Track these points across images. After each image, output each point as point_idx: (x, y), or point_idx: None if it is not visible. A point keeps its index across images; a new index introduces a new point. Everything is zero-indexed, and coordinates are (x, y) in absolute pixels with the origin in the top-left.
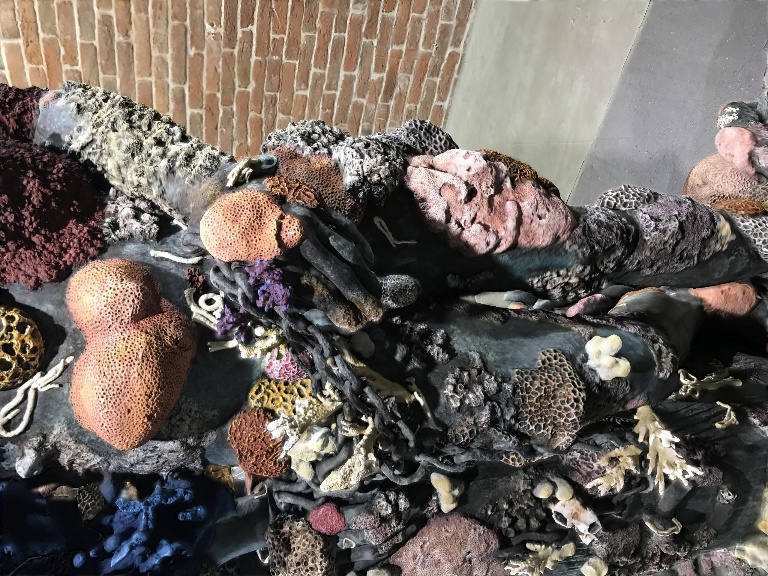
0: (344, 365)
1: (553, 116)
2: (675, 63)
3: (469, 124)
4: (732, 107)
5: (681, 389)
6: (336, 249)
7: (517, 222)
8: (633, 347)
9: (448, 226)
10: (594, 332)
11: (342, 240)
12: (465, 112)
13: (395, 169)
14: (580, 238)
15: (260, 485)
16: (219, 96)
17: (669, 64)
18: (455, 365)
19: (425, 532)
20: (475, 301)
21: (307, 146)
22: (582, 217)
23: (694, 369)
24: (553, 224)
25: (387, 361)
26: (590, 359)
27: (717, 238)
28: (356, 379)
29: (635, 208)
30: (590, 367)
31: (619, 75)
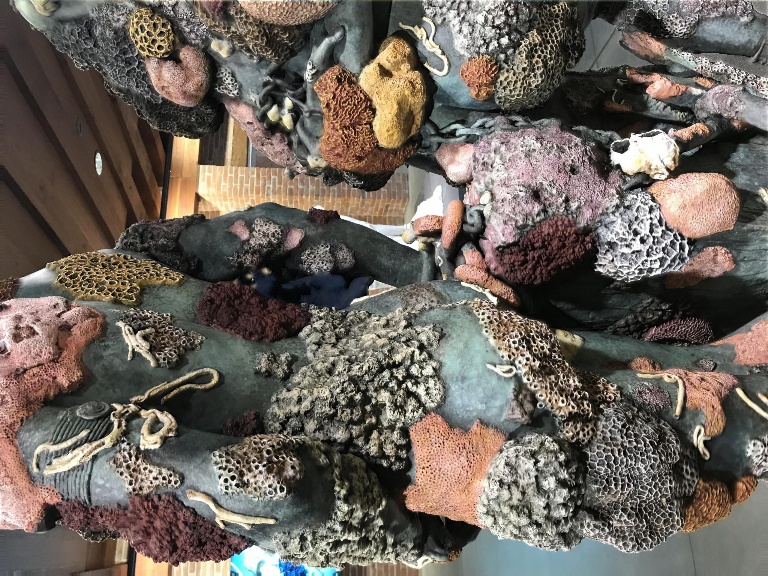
0: None
1: None
2: None
3: None
4: None
5: None
6: None
7: None
8: None
9: None
10: None
11: None
12: None
13: None
14: None
15: (424, 239)
16: None
17: None
18: None
19: None
20: None
21: None
22: None
23: None
24: None
25: None
26: None
27: None
28: None
29: None
30: None
31: None
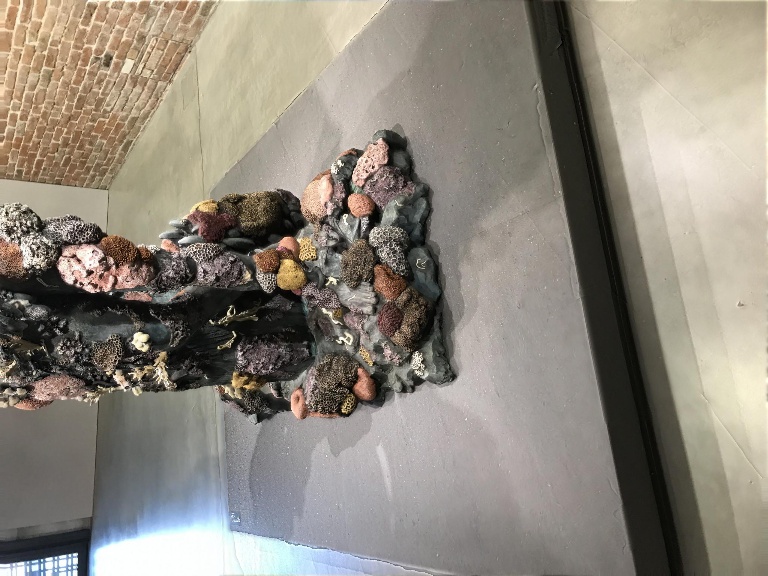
0: (2, 350)
1: (328, 3)
2: (365, 76)
3: None
4: (341, 162)
5: (222, 319)
6: (1, 321)
7: (113, 284)
8: (161, 335)
9: (75, 285)
10: (143, 327)
11: (4, 318)
12: None
13: (51, 261)
14: (153, 284)
15: None
16: None
17: (363, 73)
18: (66, 337)
19: (48, 378)
20: (98, 292)
21: (8, 237)
22: (160, 272)
23: (239, 306)
24: (135, 284)
25: (33, 331)
26: (133, 341)
27: (241, 280)
28: (7, 354)
29: (200, 263)
30: (132, 344)
31: (367, 20)
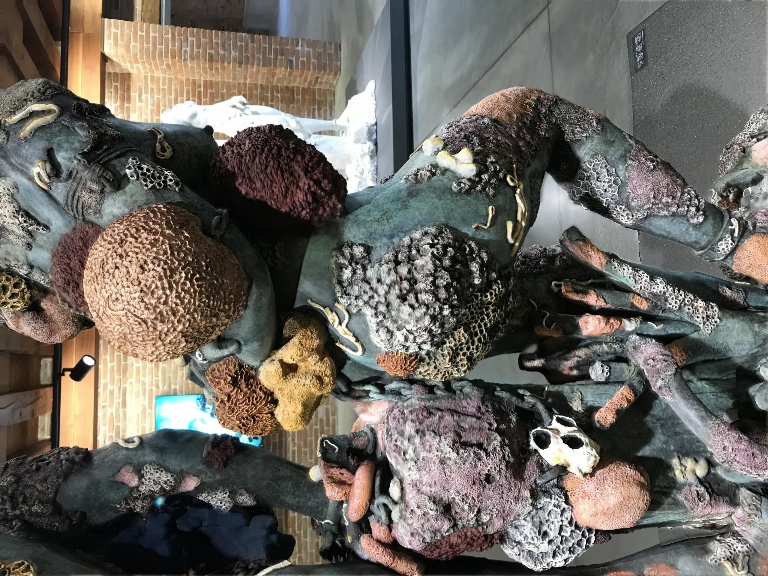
0: None
1: None
2: None
3: None
4: None
5: None
6: None
7: None
8: None
9: None
10: None
11: None
12: None
13: None
14: None
15: None
16: None
17: None
18: None
19: None
20: None
21: None
22: None
23: None
24: None
25: None
26: None
27: None
28: None
29: None
30: None
31: None
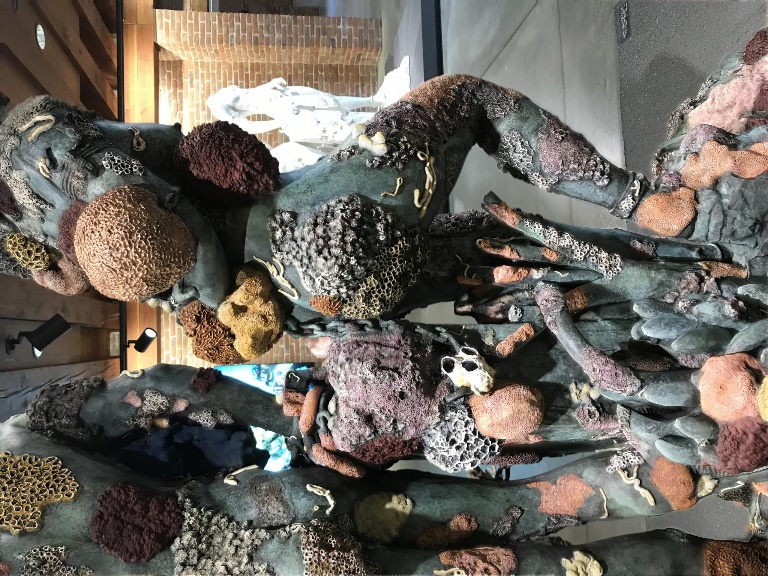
0: None
1: None
2: None
3: None
4: None
5: None
6: None
7: None
8: None
9: None
10: None
11: None
12: None
13: None
14: None
15: None
16: None
17: None
18: None
19: None
20: None
21: None
22: None
23: None
24: None
25: None
26: None
27: None
28: None
29: None
30: None
31: None
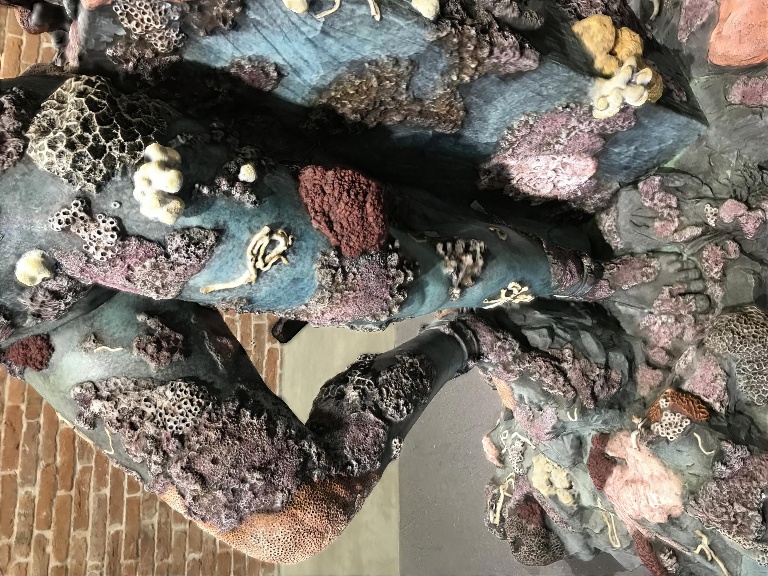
0: None
1: None
2: None
3: (301, 399)
4: None
5: None
6: None
7: None
8: None
9: None
10: None
11: None
12: (295, 394)
13: None
14: None
15: None
16: (24, 409)
17: None
18: None
19: None
20: None
21: None
22: None
23: None
24: None
25: None
26: None
27: None
28: None
29: None
30: None
31: None
